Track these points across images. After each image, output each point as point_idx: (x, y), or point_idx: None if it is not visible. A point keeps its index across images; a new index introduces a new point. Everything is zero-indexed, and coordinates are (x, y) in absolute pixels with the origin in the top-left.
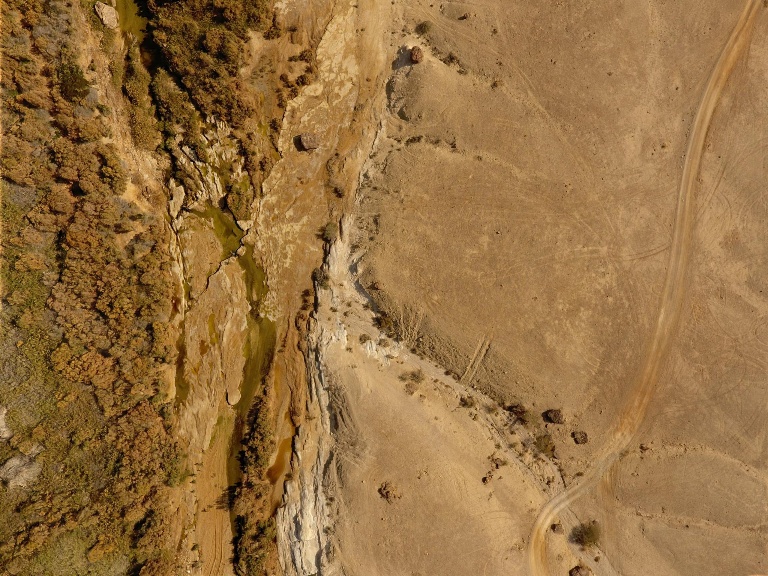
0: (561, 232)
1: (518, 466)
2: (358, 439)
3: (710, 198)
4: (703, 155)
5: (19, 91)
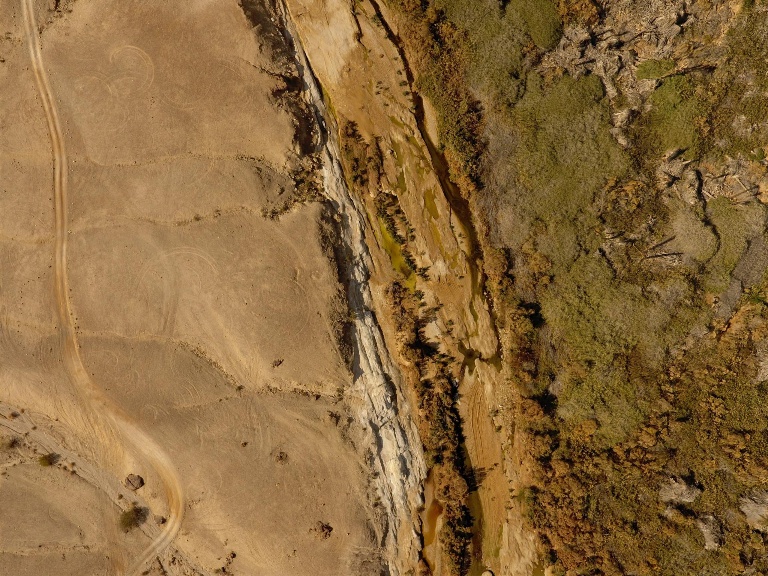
0: None
1: (204, 570)
2: (359, 571)
3: None
4: None
5: None
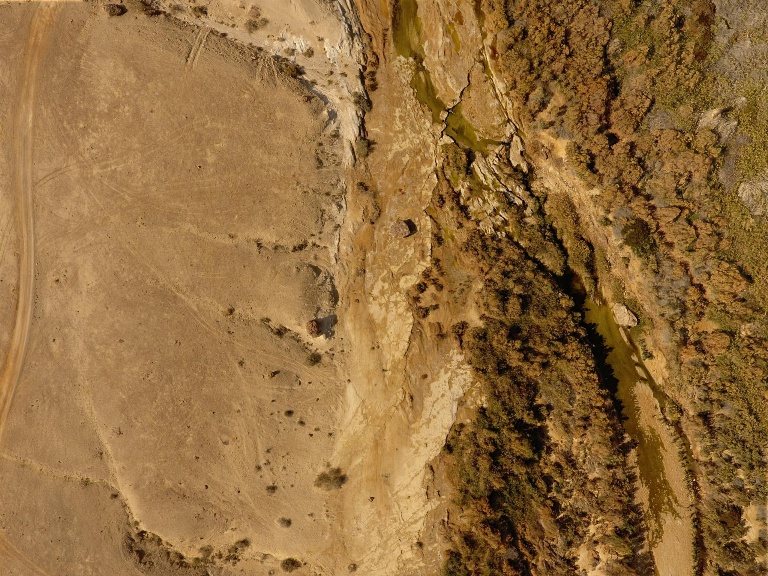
0: (139, 179)
1: None
2: None
3: (4, 240)
4: (18, 280)
5: (689, 221)
